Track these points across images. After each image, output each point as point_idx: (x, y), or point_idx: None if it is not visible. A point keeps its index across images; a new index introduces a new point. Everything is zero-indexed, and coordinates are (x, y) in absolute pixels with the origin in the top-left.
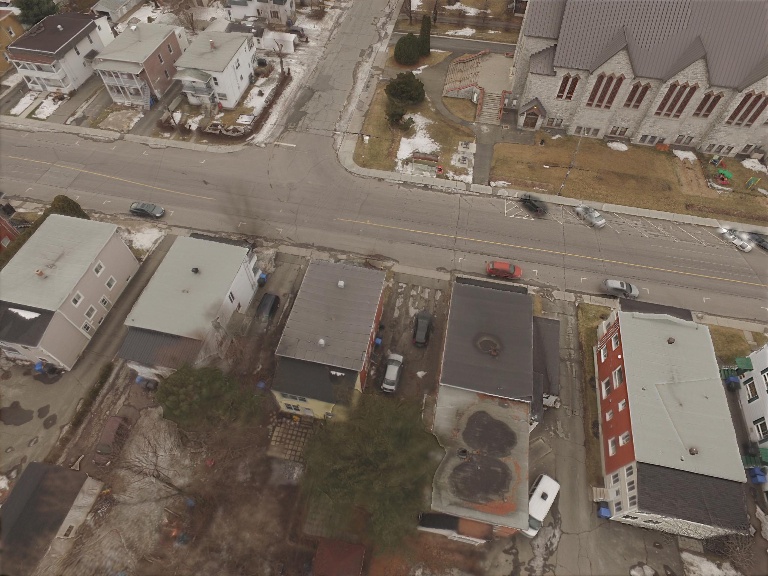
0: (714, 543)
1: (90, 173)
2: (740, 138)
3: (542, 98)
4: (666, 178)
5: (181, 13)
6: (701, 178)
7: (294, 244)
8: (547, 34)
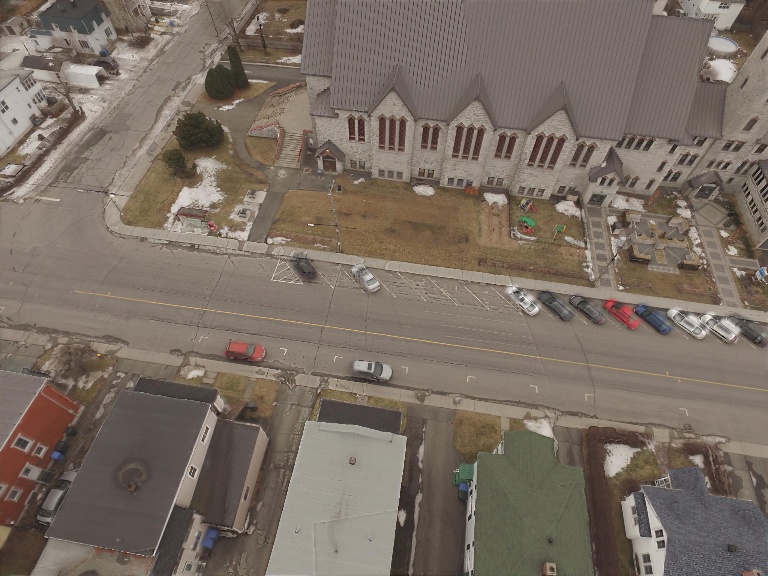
0: None
1: None
2: (548, 180)
3: (335, 140)
4: (466, 227)
5: None
6: (505, 226)
7: (12, 326)
8: (324, 72)
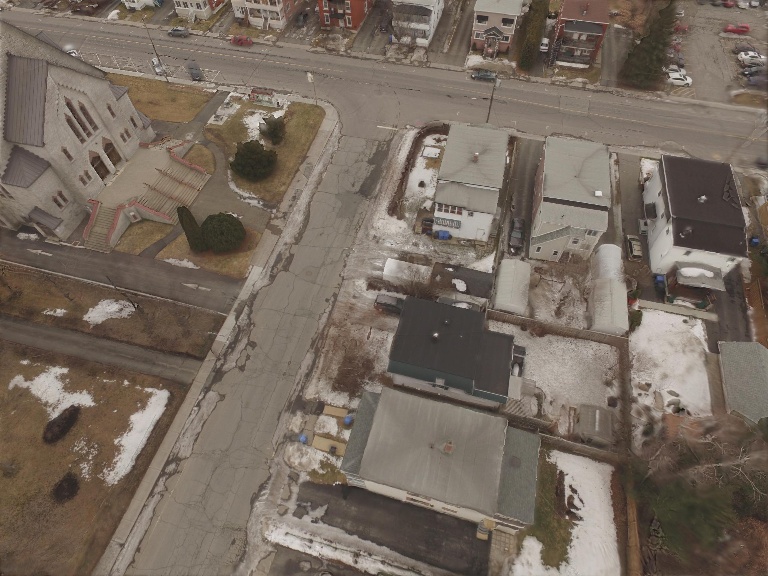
0: None
1: (550, 106)
2: None
3: None
4: None
5: (615, 382)
6: None
7: (374, 60)
8: None
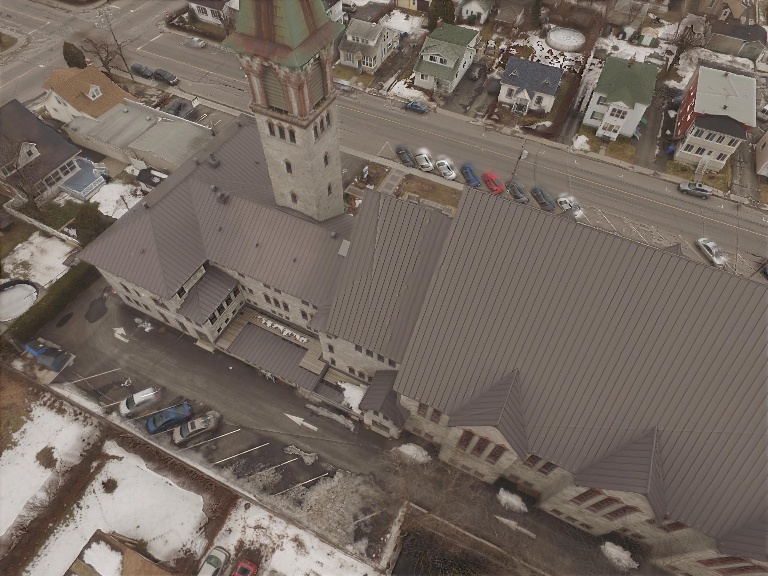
0: (674, 93)
1: None
2: None
3: None
4: None
5: None
6: None
7: None
8: None
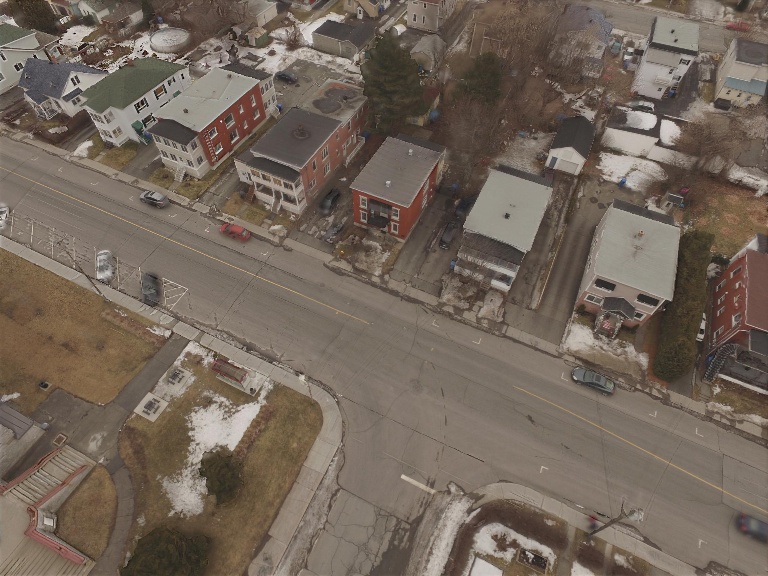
0: None
1: (706, 480)
2: None
3: None
4: None
5: None
6: None
7: (421, 304)
8: None
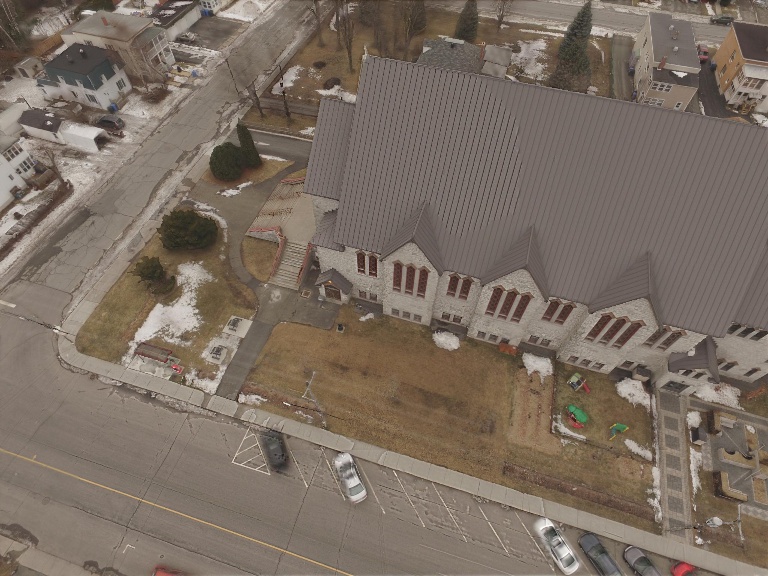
0: None
1: None
2: (610, 357)
3: (340, 270)
4: (494, 408)
5: None
6: (545, 413)
7: None
8: (332, 194)
